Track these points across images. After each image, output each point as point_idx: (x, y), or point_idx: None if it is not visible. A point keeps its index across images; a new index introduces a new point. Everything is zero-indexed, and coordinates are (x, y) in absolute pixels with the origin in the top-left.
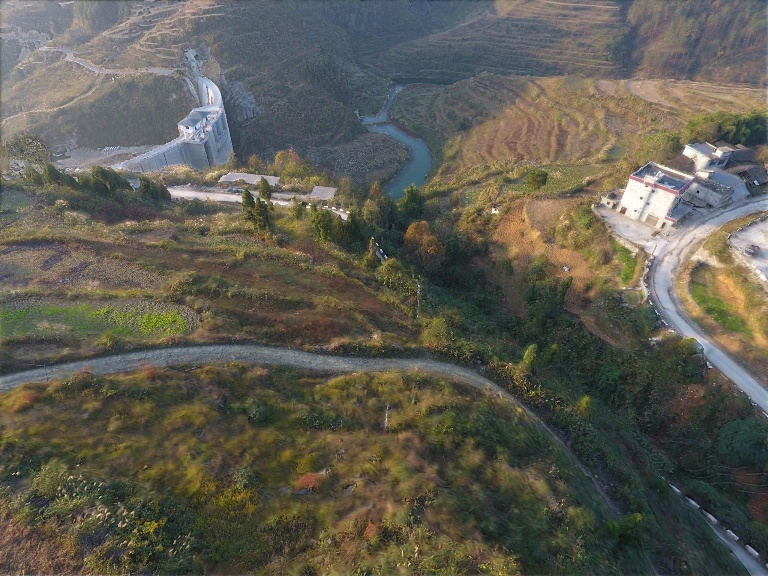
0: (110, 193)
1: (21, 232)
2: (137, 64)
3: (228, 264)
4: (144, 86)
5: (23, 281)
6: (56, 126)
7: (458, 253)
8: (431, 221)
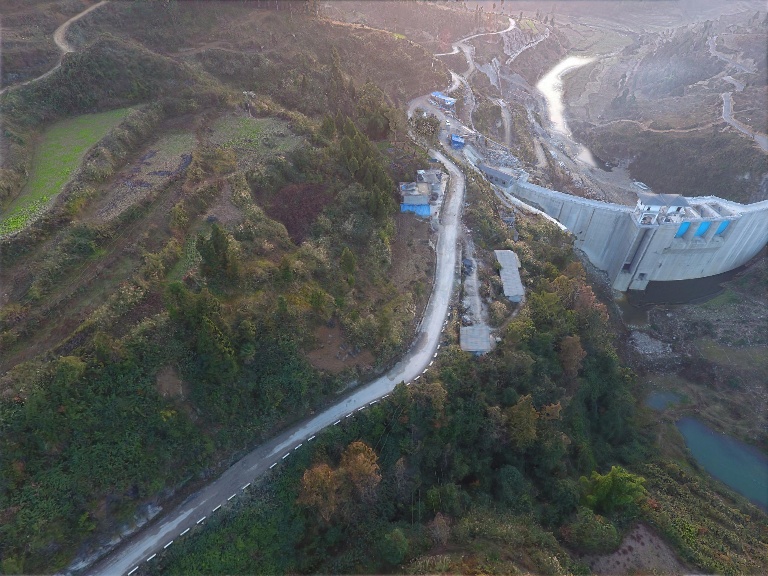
0: (354, 181)
1: (207, 153)
2: (762, 126)
3: (127, 249)
4: (731, 150)
5: (137, 170)
6: (631, 143)
7: (387, 558)
8: (558, 531)
